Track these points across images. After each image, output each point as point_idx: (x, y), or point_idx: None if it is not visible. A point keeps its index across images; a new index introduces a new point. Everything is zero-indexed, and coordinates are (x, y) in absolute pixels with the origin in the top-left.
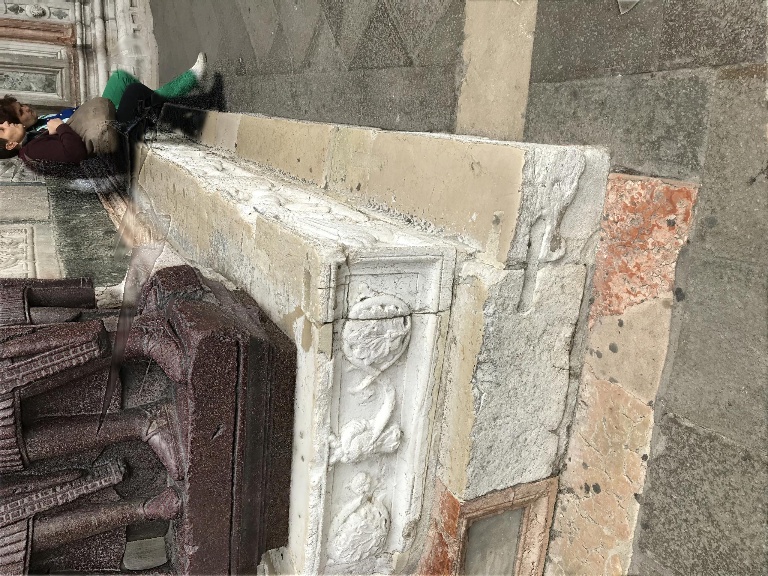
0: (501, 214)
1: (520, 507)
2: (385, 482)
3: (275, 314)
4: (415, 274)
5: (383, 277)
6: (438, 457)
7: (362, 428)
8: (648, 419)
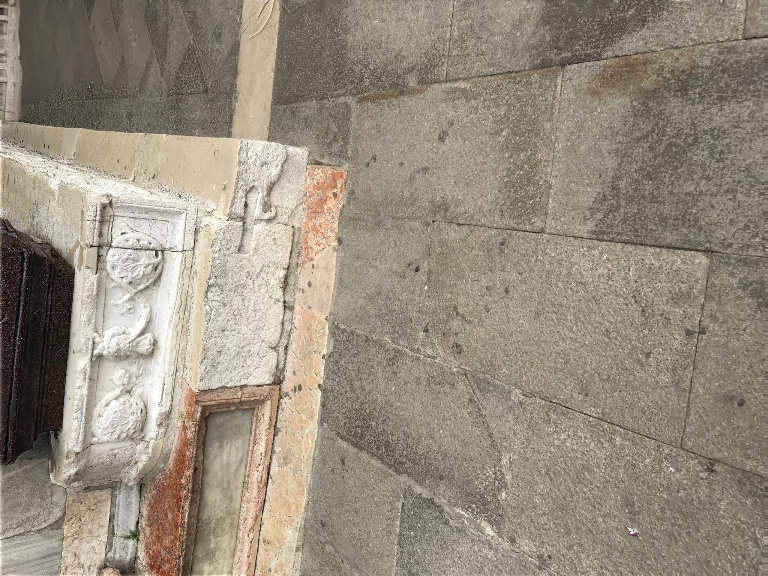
0: (227, 183)
1: (249, 407)
2: (143, 380)
3: (64, 252)
4: (166, 222)
5: (140, 220)
6: (185, 363)
7: (121, 331)
8: (325, 329)
